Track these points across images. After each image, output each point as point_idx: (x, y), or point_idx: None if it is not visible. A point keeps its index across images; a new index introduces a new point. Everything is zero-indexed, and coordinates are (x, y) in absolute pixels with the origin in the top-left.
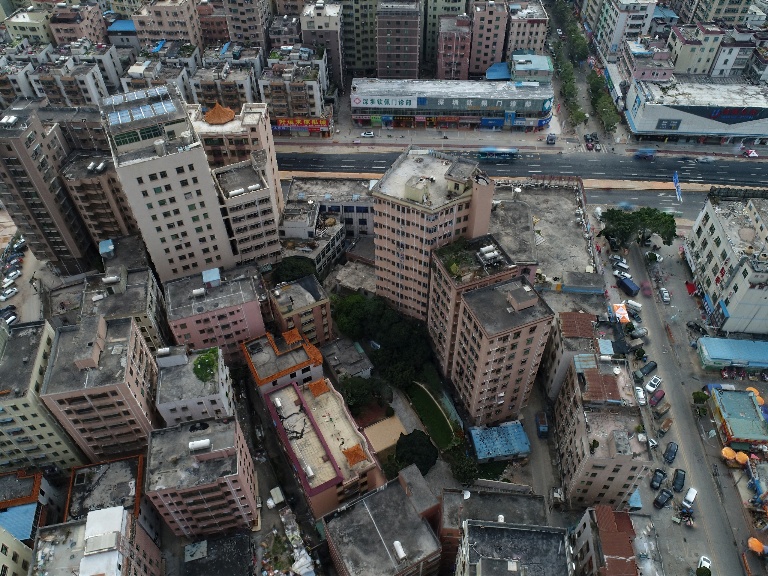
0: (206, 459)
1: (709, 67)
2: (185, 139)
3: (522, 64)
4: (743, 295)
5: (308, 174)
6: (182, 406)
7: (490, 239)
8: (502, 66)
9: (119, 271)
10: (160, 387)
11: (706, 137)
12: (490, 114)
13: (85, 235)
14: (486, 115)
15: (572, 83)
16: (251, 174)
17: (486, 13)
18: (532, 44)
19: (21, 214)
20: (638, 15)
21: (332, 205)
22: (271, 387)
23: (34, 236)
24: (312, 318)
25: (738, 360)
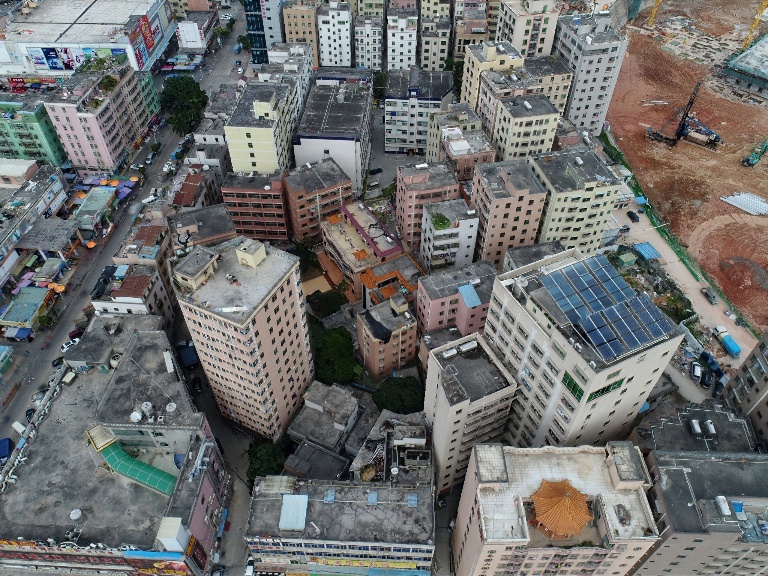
0: None
1: None
2: None
3: None
4: None
5: None
6: None
7: None
8: None
9: None
10: None
11: None
12: None
13: None
14: None
15: None
16: None
17: None
18: None
19: None
20: None
21: None
22: None
23: None
24: None
25: None
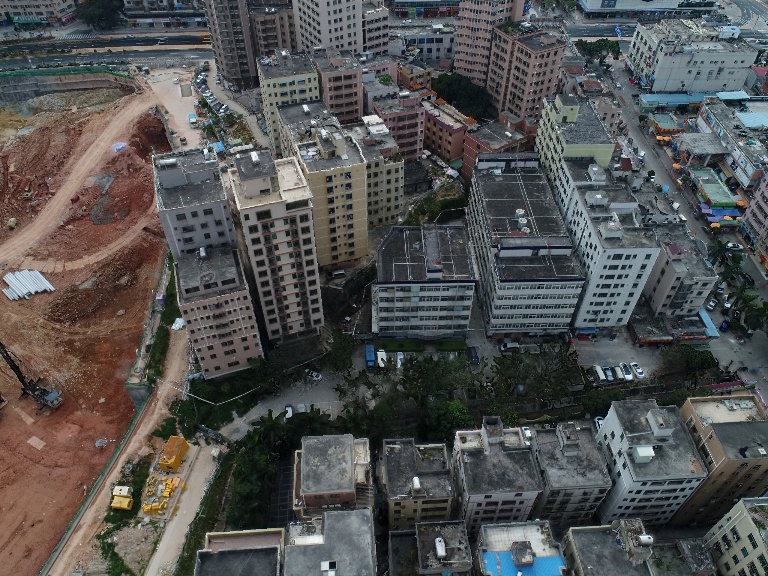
0: (405, 106)
1: None
2: None
3: None
4: (661, 61)
5: None
6: (380, 95)
7: None
8: None
9: None
10: None
11: (633, 13)
12: None
13: None
14: None
15: None
16: (373, 7)
17: None
18: None
19: (228, 39)
20: None
21: (411, 38)
22: None
23: (230, 58)
24: (422, 81)
25: (662, 102)
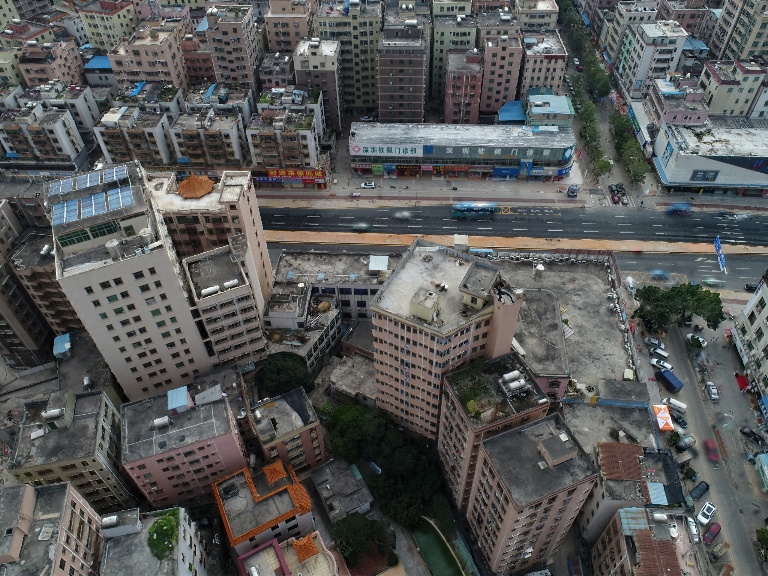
0: None
1: (747, 108)
2: (144, 238)
3: (539, 106)
4: None
5: (301, 234)
6: None
7: (514, 358)
8: (516, 105)
9: (64, 399)
10: (104, 568)
11: (746, 188)
12: (504, 163)
13: (42, 323)
14: (500, 164)
15: (594, 125)
16: (229, 263)
17: (499, 49)
18: (549, 81)
19: None
20: (666, 49)
21: (326, 287)
22: (248, 543)
23: None
24: (300, 443)
25: None
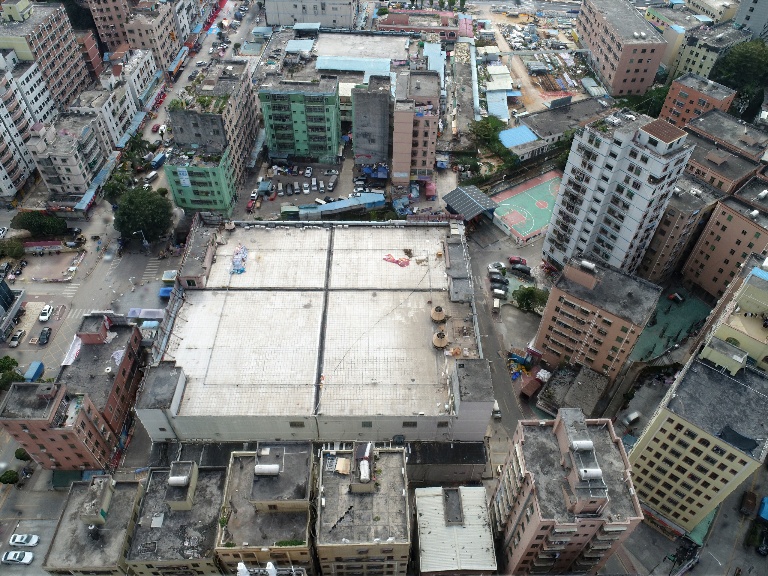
0: None
1: None
2: None
3: None
4: None
5: None
6: None
7: None
8: None
9: None
10: None
11: None
12: None
13: None
14: None
15: None
16: None
17: None
18: None
19: None
20: None
21: None
22: None
23: None
24: None
25: (267, 33)
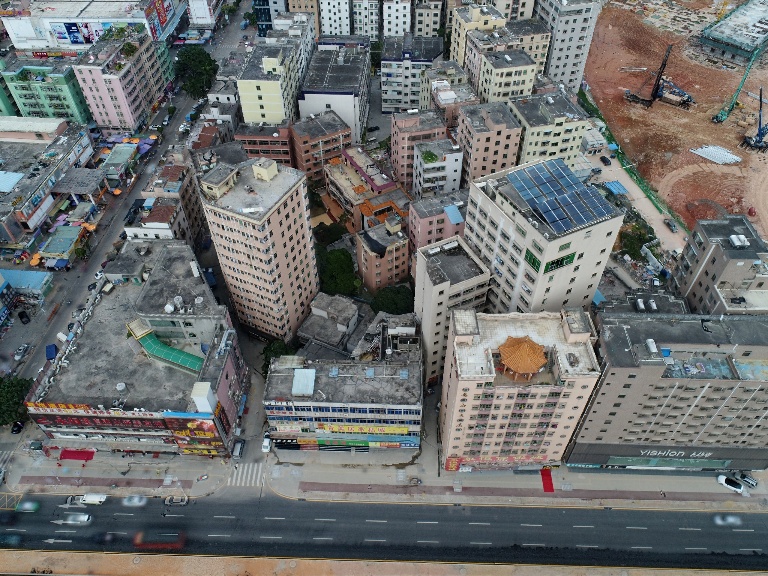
0: None
1: None
2: None
3: None
4: None
5: None
6: None
7: None
8: None
9: None
10: None
11: None
12: None
13: None
14: None
15: None
16: None
17: None
18: None
19: None
20: None
21: None
22: None
23: None
24: None
25: None
